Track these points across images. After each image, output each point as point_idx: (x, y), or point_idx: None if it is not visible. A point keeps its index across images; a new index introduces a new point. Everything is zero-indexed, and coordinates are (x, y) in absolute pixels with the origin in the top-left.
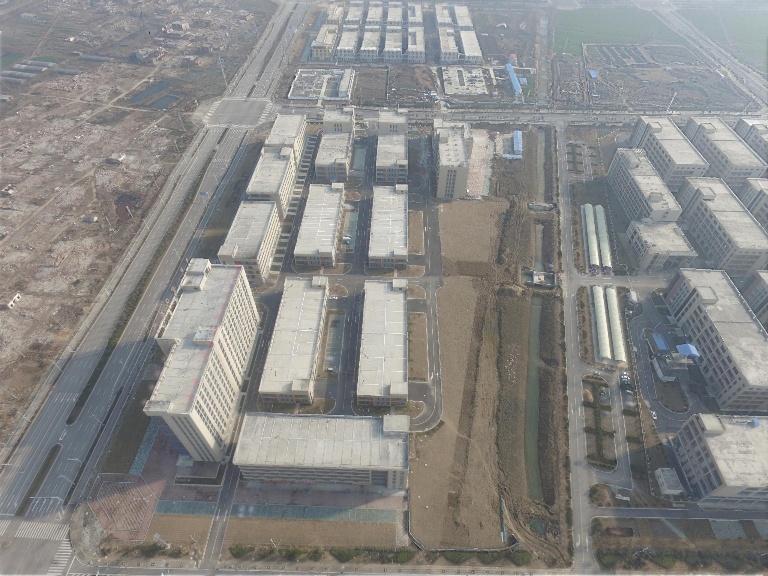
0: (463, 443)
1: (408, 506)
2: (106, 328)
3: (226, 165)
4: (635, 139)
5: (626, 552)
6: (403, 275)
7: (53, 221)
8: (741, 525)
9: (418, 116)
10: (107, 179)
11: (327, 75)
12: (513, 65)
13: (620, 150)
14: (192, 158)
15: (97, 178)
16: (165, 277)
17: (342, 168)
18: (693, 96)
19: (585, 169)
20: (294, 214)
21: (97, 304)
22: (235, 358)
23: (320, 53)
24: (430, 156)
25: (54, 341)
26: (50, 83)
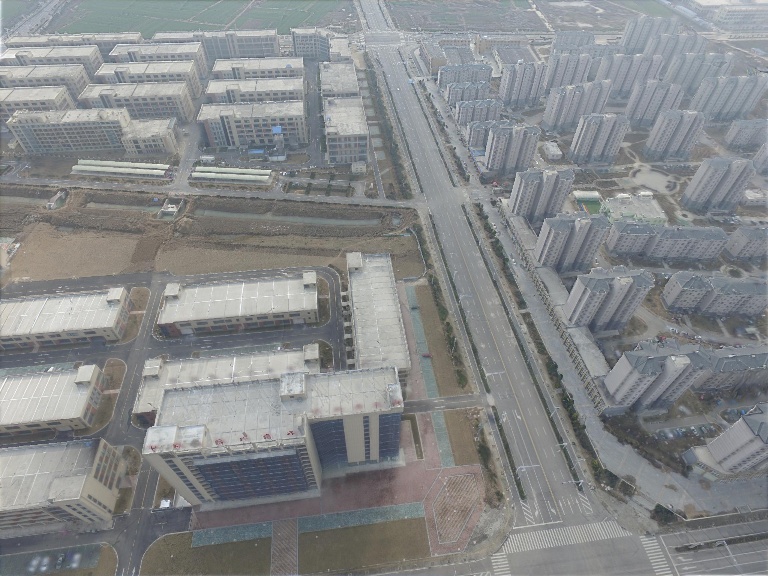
0: None
1: (401, 280)
2: None
3: None
4: None
5: (403, 187)
6: (144, 305)
7: None
8: (377, 151)
9: None
10: None
11: None
12: None
13: (10, 122)
14: None
15: None
16: None
17: None
18: None
19: (5, 165)
20: None
21: None
22: None
23: None
24: None
25: None
26: None
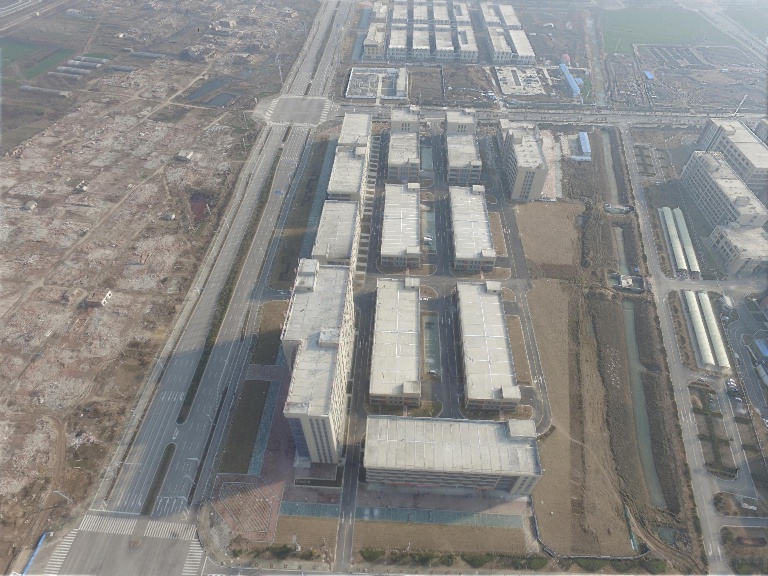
0: (578, 448)
1: (533, 512)
2: (201, 327)
3: (296, 164)
4: (704, 142)
5: (762, 562)
6: (490, 277)
7: (131, 218)
8: None
9: (479, 116)
10: (178, 177)
11: (381, 74)
12: (566, 65)
13: (697, 153)
14: (259, 156)
15: (168, 175)
16: (252, 276)
17: (415, 168)
18: (754, 98)
19: (656, 171)
20: (371, 214)
21: (188, 302)
22: (345, 359)
23: (372, 51)
24: (498, 157)
25: (151, 339)
26: (106, 79)
